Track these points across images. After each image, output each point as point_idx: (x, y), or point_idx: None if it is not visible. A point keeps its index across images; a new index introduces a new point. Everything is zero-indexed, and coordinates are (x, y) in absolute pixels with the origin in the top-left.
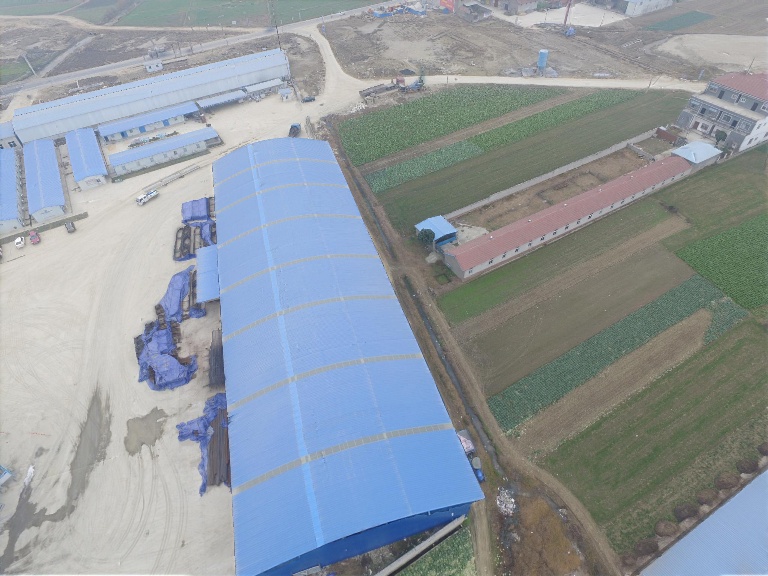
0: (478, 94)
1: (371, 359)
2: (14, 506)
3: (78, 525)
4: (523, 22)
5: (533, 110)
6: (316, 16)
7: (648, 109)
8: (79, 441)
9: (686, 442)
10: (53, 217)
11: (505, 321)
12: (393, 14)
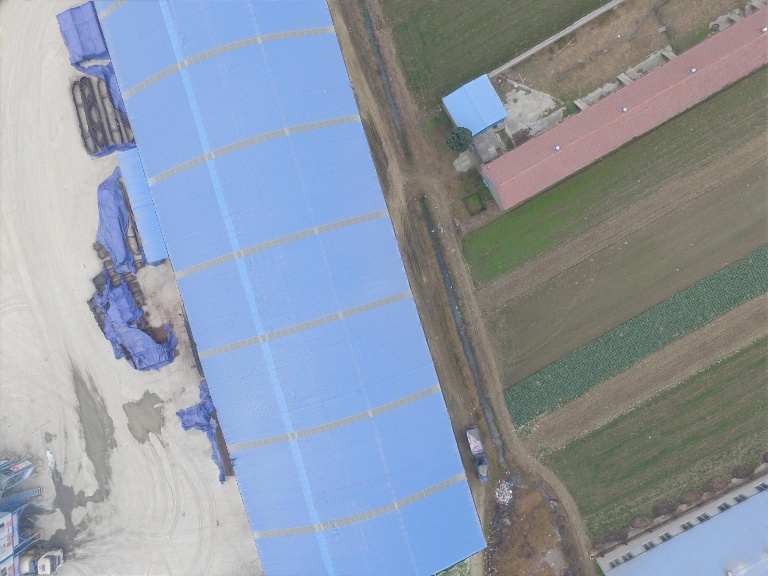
0: None
1: (380, 410)
2: (52, 488)
3: (119, 506)
4: None
5: None
6: None
7: None
8: (82, 427)
9: (696, 446)
10: None
11: (545, 281)
12: None
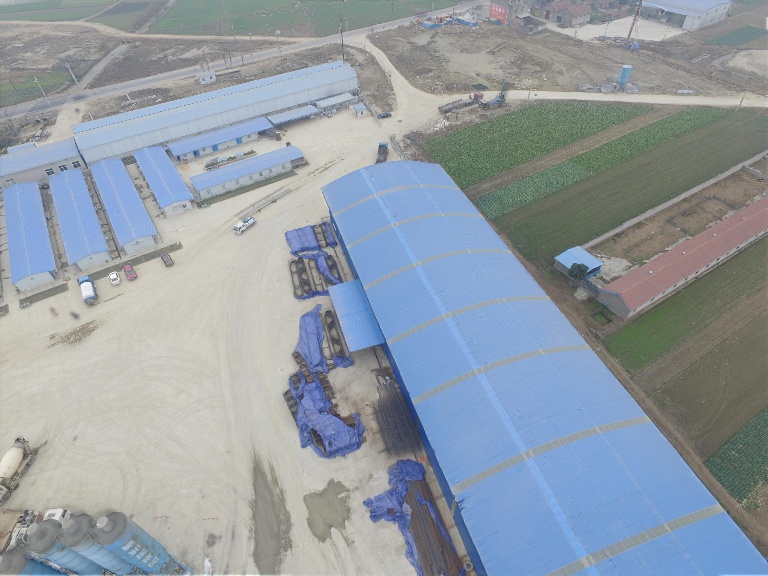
0: (563, 111)
1: (606, 427)
2: None
3: None
4: (581, 35)
5: (627, 128)
6: (361, 26)
7: (745, 128)
8: (254, 525)
9: None
10: (144, 248)
11: (688, 367)
12: (443, 25)
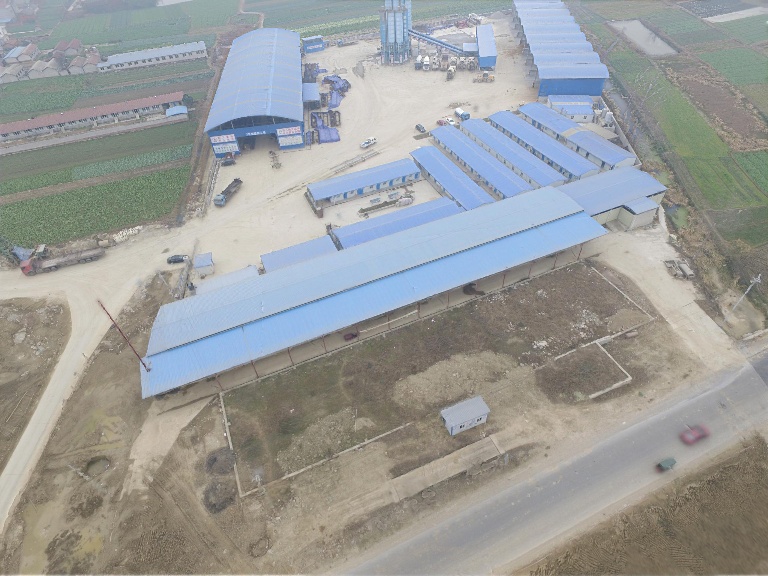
0: None
1: None
2: None
3: None
4: None
5: None
6: None
7: None
8: None
9: None
10: None
11: None
12: None
